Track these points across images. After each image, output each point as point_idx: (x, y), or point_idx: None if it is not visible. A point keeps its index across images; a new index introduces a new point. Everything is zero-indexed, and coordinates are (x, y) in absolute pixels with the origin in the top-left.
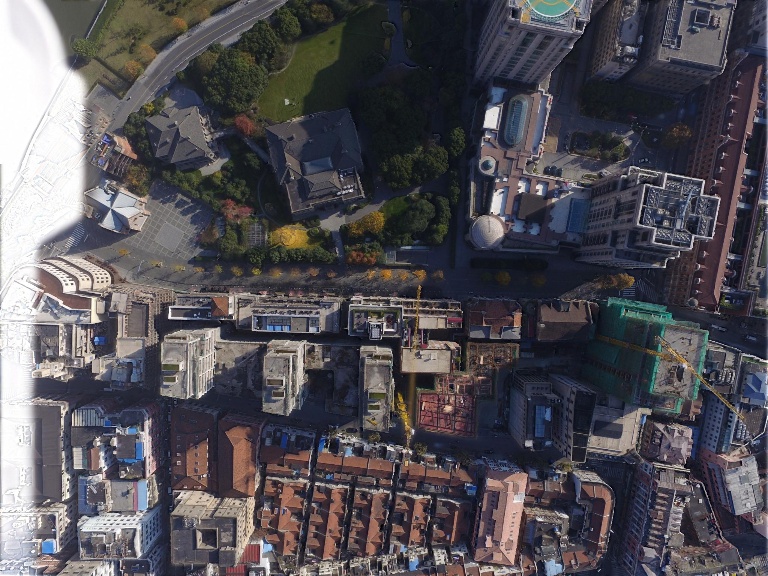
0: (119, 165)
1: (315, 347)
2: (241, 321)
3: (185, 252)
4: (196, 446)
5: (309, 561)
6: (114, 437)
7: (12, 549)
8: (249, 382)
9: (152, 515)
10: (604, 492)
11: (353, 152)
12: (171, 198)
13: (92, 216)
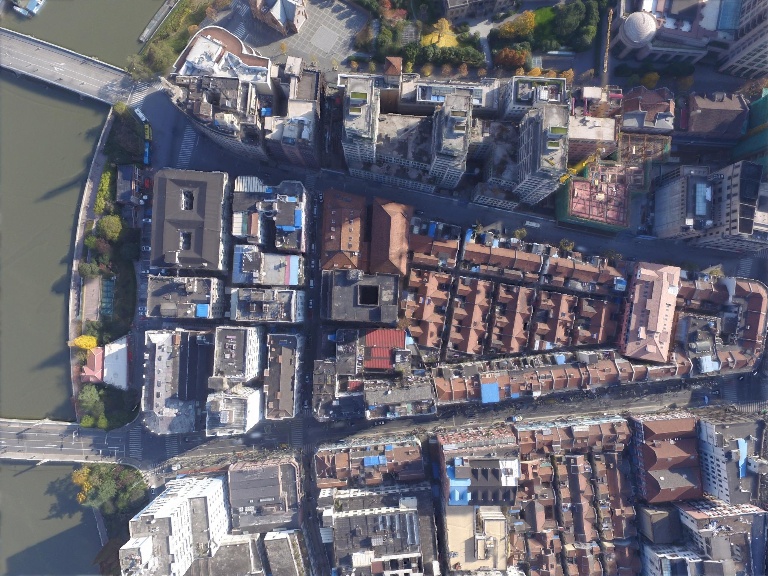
0: None
1: (476, 120)
2: (404, 95)
3: (338, 53)
4: (351, 221)
5: (451, 356)
6: (275, 202)
7: (168, 309)
8: (409, 154)
9: (301, 292)
10: (760, 288)
11: None
12: (328, 3)
13: (259, 8)
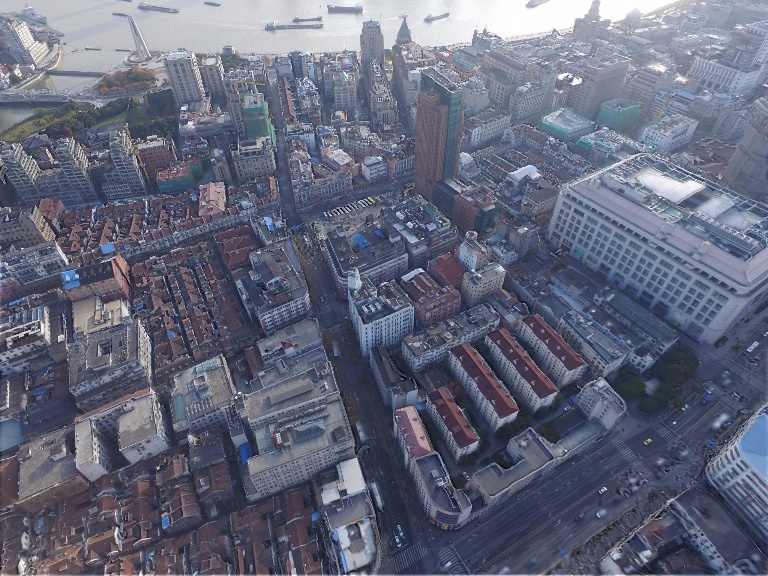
0: (1, 149)
1: None
2: None
3: None
4: None
5: None
6: None
7: None
8: None
9: None
10: None
11: (122, 128)
12: None
13: None
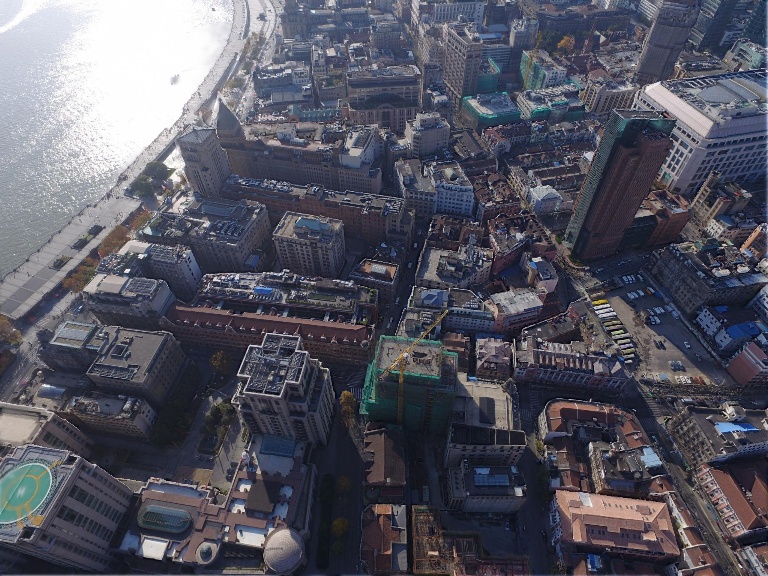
0: None
1: None
2: None
3: None
4: None
5: None
6: None
7: None
8: None
9: None
10: (553, 409)
11: None
12: None
13: None
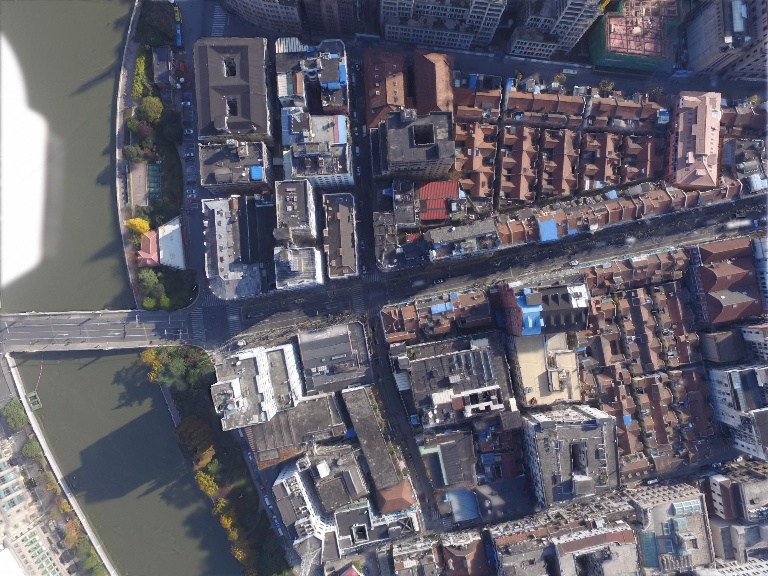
0: None
1: None
2: None
3: None
4: (394, 75)
5: (504, 205)
6: None
7: (223, 174)
8: (447, 0)
9: None
10: None
11: None
12: None
13: None
